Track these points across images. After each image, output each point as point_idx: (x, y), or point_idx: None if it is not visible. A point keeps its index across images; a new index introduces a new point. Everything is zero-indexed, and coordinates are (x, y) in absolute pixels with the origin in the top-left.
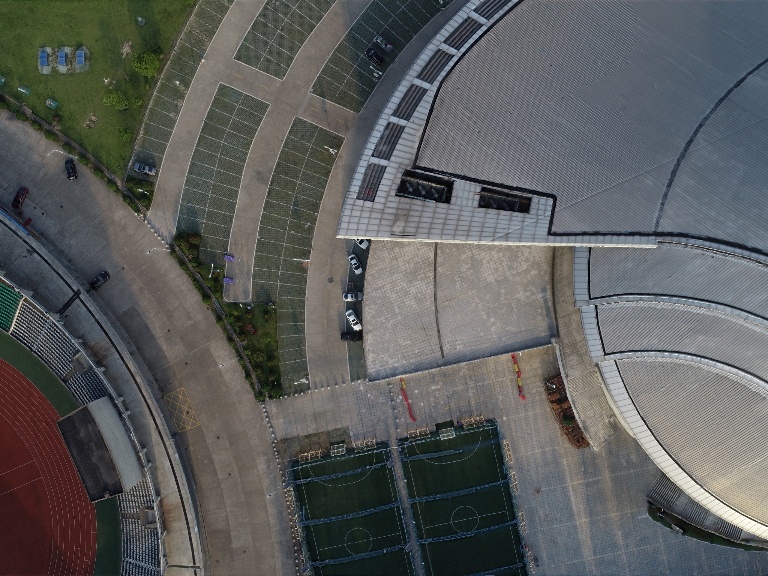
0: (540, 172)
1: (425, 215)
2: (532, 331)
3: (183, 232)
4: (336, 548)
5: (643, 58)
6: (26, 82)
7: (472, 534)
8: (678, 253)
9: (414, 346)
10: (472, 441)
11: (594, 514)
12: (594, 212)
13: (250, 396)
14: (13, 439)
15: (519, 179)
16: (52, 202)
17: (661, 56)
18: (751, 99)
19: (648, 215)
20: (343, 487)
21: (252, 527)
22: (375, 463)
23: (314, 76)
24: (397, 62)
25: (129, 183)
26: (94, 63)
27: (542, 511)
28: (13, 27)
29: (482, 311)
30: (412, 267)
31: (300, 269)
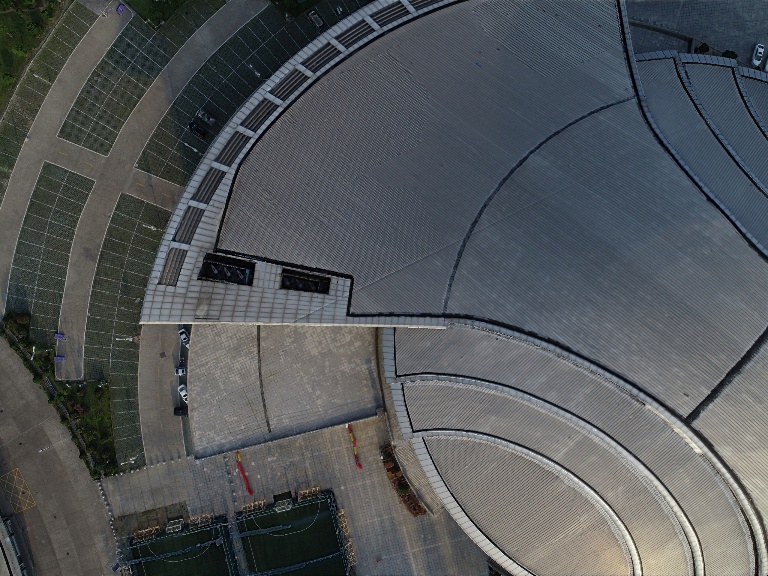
0: (338, 253)
1: (228, 298)
2: (358, 403)
3: (12, 312)
4: None
5: (433, 137)
6: None
7: None
8: (467, 334)
9: (240, 422)
10: (311, 512)
11: None
12: (388, 293)
13: (86, 474)
14: None
15: (318, 260)
16: None
17: (450, 135)
18: (531, 179)
19: (437, 296)
20: (182, 563)
21: None
22: (214, 537)
23: (139, 151)
24: None
25: None
26: None
27: None
28: None
29: (307, 384)
30: (235, 343)
31: (132, 345)
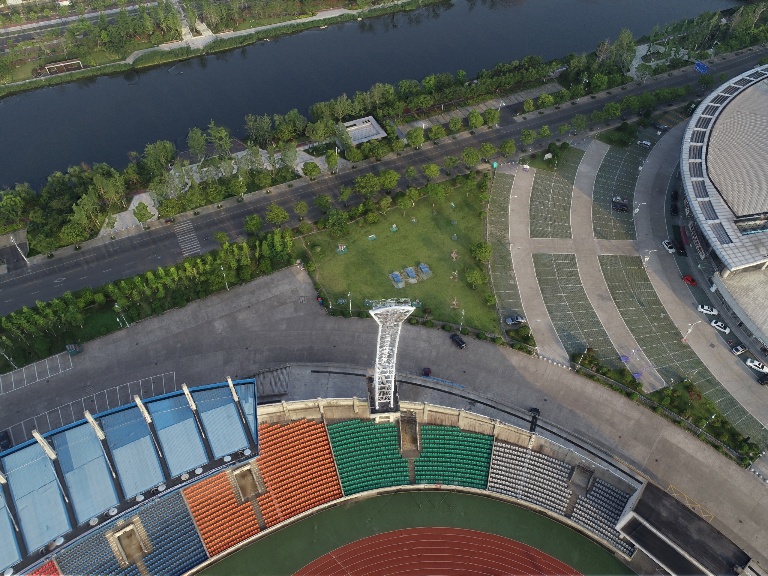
0: None
1: None
2: None
3: (575, 354)
4: None
5: None
6: (390, 297)
7: None
8: None
9: None
10: None
11: None
12: None
13: (733, 467)
14: None
15: None
16: (454, 371)
17: None
18: None
19: None
20: None
21: None
22: None
23: (591, 230)
24: (636, 208)
25: (512, 332)
26: (435, 270)
27: None
28: (364, 268)
29: None
30: None
31: (683, 347)
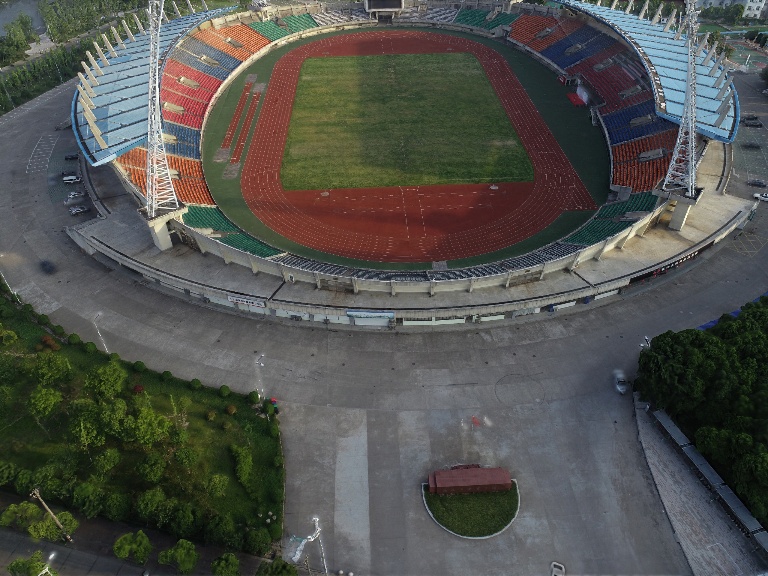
0: None
1: None
2: None
3: None
4: None
5: None
6: None
7: None
8: None
9: None
10: None
11: None
12: None
13: None
14: None
15: None
16: None
17: None
18: None
19: None
20: None
21: None
22: None
23: None
24: None
25: None
26: None
27: None
28: None
29: None
30: None
31: None
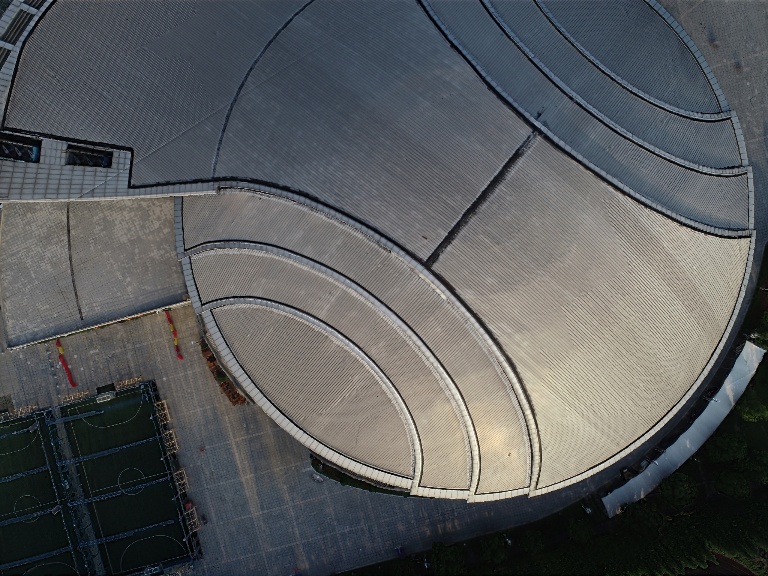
0: (119, 126)
1: (16, 176)
2: (168, 289)
3: None
4: (6, 516)
5: (208, 6)
6: None
7: (119, 494)
8: (236, 197)
9: (53, 310)
10: (134, 403)
11: (259, 469)
12: (165, 162)
13: None
14: None
15: (101, 134)
16: None
17: (224, 3)
18: (294, 39)
19: (207, 161)
20: (9, 455)
21: None
22: None
23: None
24: None
25: None
26: None
27: (207, 469)
28: None
29: (117, 272)
30: (45, 231)
31: None
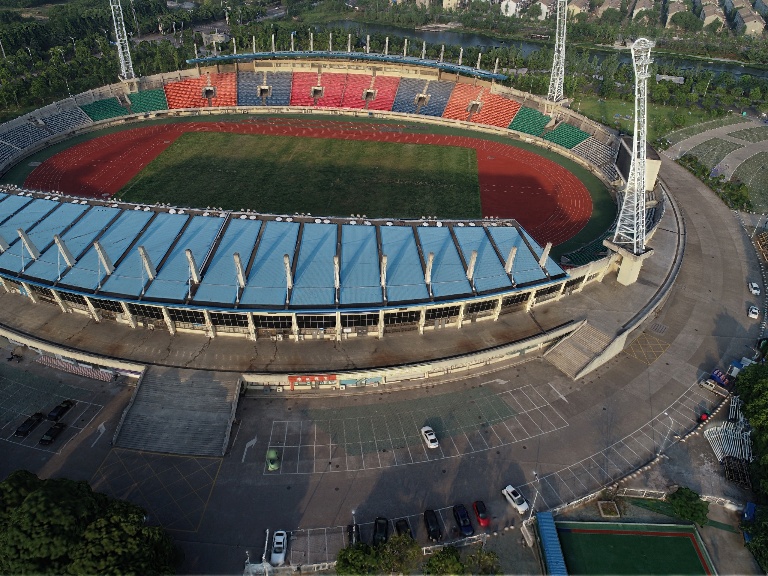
0: None
1: None
2: None
3: None
4: None
5: None
6: None
7: None
8: None
9: None
10: None
11: None
12: None
13: None
14: (545, 181)
15: None
16: None
17: None
18: None
19: None
20: None
21: (721, 249)
22: None
23: None
24: None
25: None
26: None
27: None
28: None
29: None
30: None
31: (766, 183)
